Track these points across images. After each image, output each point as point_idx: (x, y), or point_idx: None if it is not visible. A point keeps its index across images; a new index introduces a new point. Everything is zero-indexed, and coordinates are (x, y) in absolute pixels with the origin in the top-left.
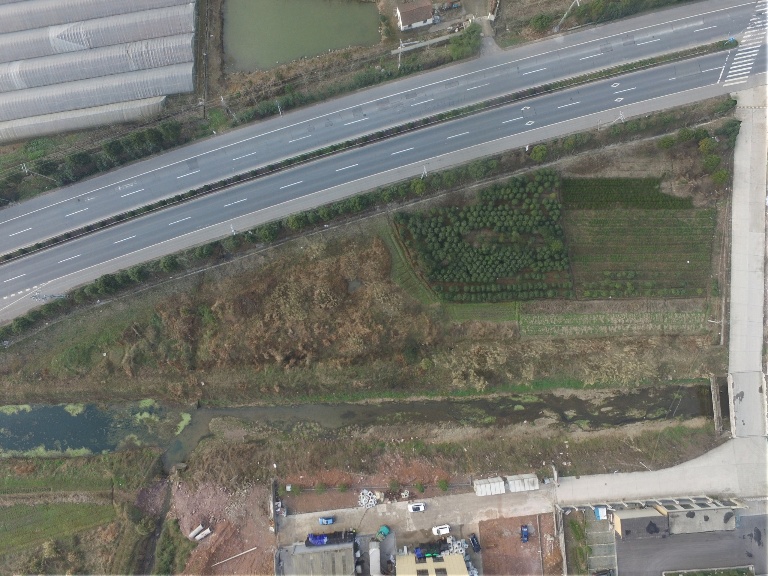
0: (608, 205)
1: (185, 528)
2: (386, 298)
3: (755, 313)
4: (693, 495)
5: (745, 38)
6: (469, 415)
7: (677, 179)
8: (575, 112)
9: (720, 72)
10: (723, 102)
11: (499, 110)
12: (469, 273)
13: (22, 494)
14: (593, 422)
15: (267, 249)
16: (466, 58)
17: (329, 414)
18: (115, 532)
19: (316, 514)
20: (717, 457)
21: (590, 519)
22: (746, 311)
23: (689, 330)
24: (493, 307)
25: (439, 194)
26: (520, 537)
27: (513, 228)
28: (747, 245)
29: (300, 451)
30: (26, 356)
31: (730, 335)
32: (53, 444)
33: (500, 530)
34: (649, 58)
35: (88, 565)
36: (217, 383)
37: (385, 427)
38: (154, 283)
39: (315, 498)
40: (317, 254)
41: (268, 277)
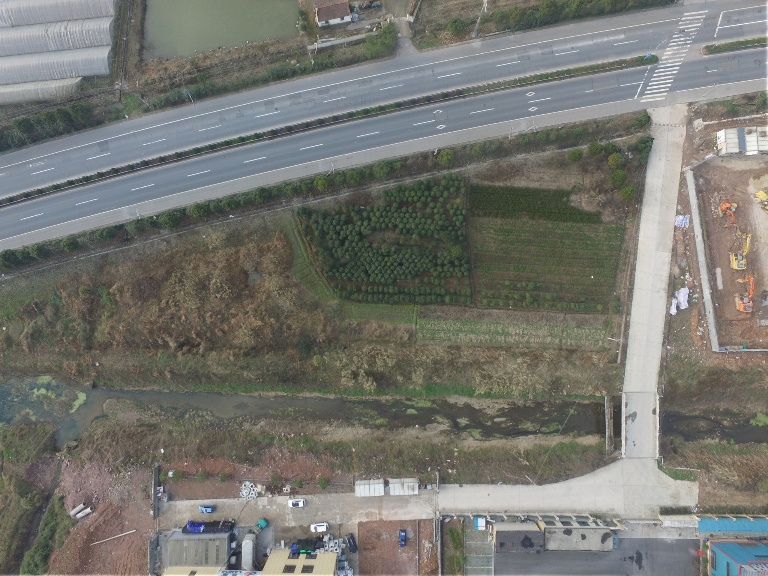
0: (515, 214)
1: (69, 505)
2: (281, 292)
3: (655, 333)
4: (576, 513)
5: (666, 54)
6: (361, 415)
7: (587, 193)
8: (487, 119)
9: (638, 87)
10: (637, 118)
11: (411, 112)
12: (368, 273)
13: None
14: (485, 432)
15: (171, 235)
16: (381, 58)
17: (222, 404)
18: (1, 504)
19: (197, 502)
20: (604, 476)
21: (470, 529)
22: (646, 331)
23: (588, 346)
24: (391, 309)
25: (346, 192)
26: (398, 541)
27: (415, 231)
28: (652, 264)
29: (190, 438)
30: None
31: (627, 354)
32: None
33: (379, 532)
34: (566, 69)
35: None
36: (111, 364)
37: (276, 421)
38: (58, 261)
39: (198, 486)
40: (216, 244)
41: (168, 263)
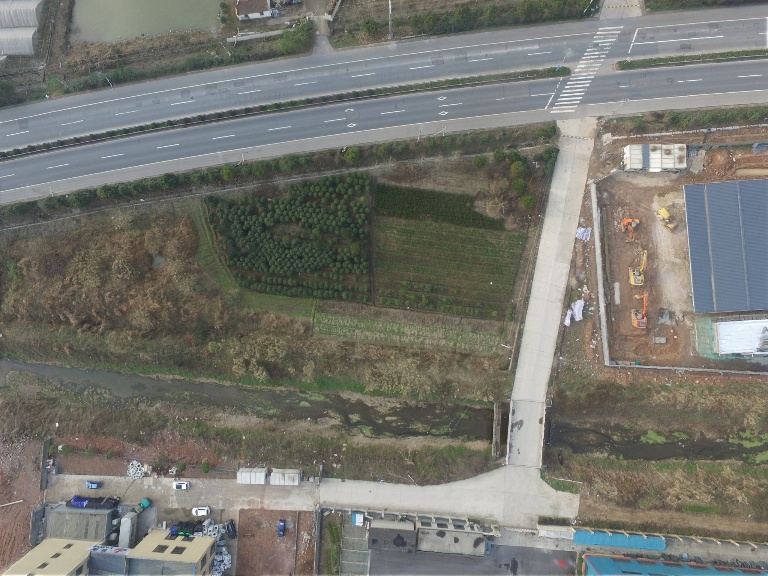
0: (418, 216)
1: None
2: (180, 277)
3: (547, 343)
4: (456, 516)
5: (579, 67)
6: (255, 404)
7: (492, 199)
8: (397, 120)
9: (549, 98)
10: (544, 128)
11: (323, 109)
12: (269, 264)
13: None
14: (376, 429)
15: (82, 215)
16: (298, 54)
17: (121, 383)
18: None
19: (85, 477)
20: (486, 482)
21: (349, 524)
22: (538, 340)
23: (481, 351)
24: (290, 301)
25: (255, 183)
26: (277, 531)
27: (316, 226)
28: (550, 274)
29: (86, 414)
30: None
31: (518, 362)
32: None
33: (259, 521)
34: (478, 76)
35: None
36: (13, 337)
37: (172, 404)
38: None
39: (87, 461)
40: (122, 225)
41: (75, 242)
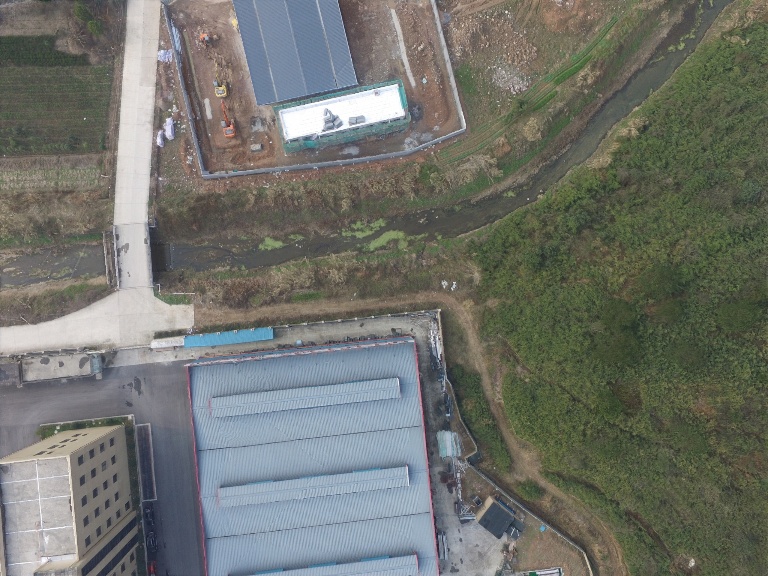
0: None
1: None
2: None
3: (142, 165)
4: (73, 347)
5: None
6: None
7: (72, 36)
8: None
9: None
10: None
11: None
12: None
13: None
14: None
15: None
16: None
17: None
18: None
19: None
20: (100, 309)
21: None
22: (133, 164)
23: (84, 186)
24: None
25: None
26: None
27: None
28: (136, 99)
29: None
30: None
31: (116, 188)
32: None
33: None
34: None
35: None
36: None
37: None
38: None
39: None
40: None
41: None
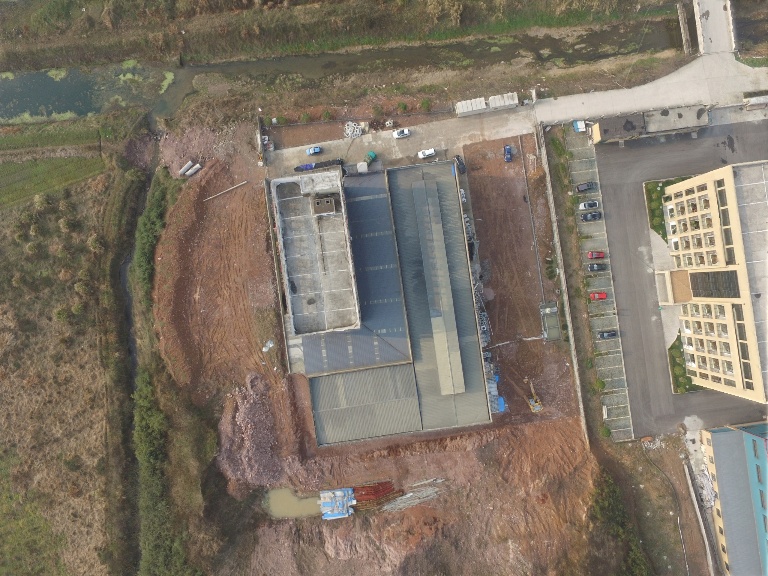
0: None
1: (175, 172)
2: None
3: None
4: None
5: None
6: (447, 59)
7: None
8: None
9: None
10: None
11: None
12: None
13: (9, 151)
14: (568, 59)
15: None
16: None
17: (310, 65)
18: (105, 182)
19: (303, 147)
20: (688, 73)
21: (570, 136)
22: None
23: None
24: None
25: None
26: (503, 157)
27: None
28: None
29: (284, 99)
30: (5, 13)
31: None
32: (38, 110)
33: (484, 153)
34: None
35: (80, 216)
36: (197, 29)
37: (366, 74)
38: None
39: (301, 132)
40: None
41: None
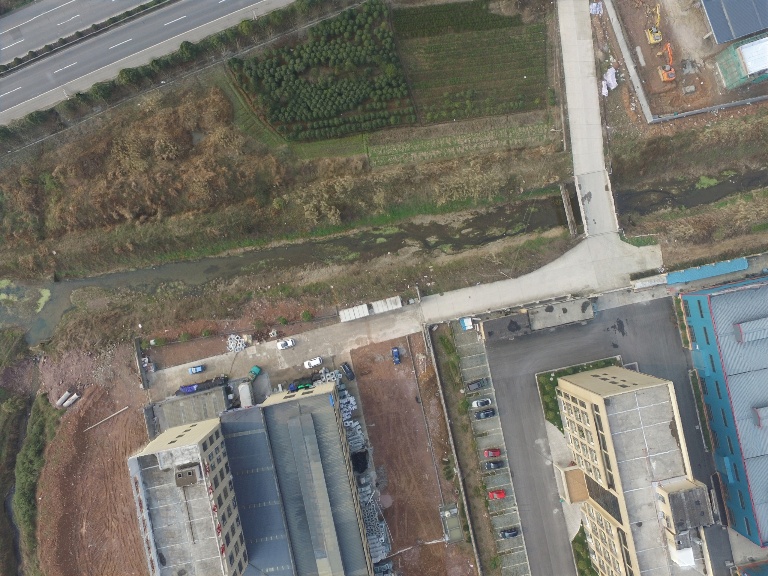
0: (440, 30)
1: (54, 400)
2: (227, 140)
3: (592, 116)
4: (555, 296)
5: None
6: (333, 254)
7: None
8: None
9: None
10: None
11: None
12: (310, 110)
13: None
14: (455, 245)
15: (105, 111)
16: None
17: (192, 271)
18: None
19: (186, 365)
20: (574, 257)
21: (458, 332)
22: (584, 115)
23: (534, 142)
24: (341, 143)
25: (273, 38)
26: (392, 360)
27: (347, 60)
28: (577, 53)
29: (166, 310)
30: None
31: (571, 140)
32: None
33: (372, 356)
34: None
35: None
36: (68, 249)
37: (250, 276)
38: None
39: (183, 350)
40: (152, 106)
41: (107, 137)
